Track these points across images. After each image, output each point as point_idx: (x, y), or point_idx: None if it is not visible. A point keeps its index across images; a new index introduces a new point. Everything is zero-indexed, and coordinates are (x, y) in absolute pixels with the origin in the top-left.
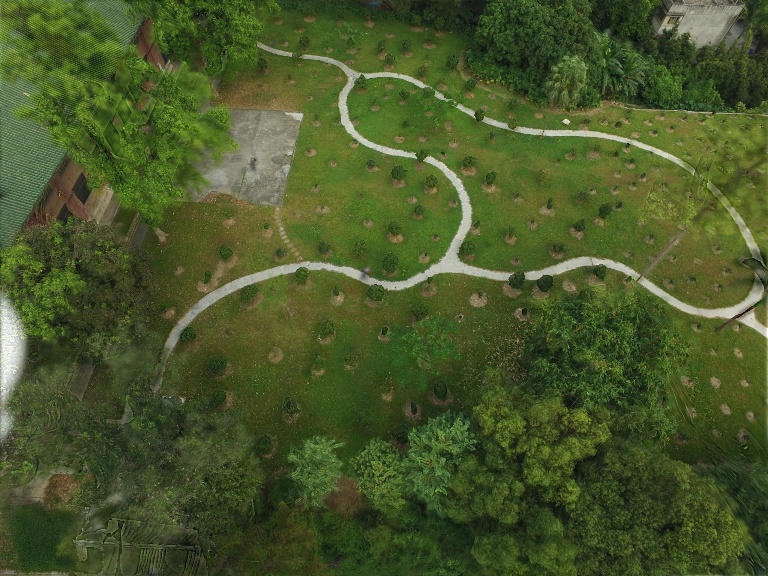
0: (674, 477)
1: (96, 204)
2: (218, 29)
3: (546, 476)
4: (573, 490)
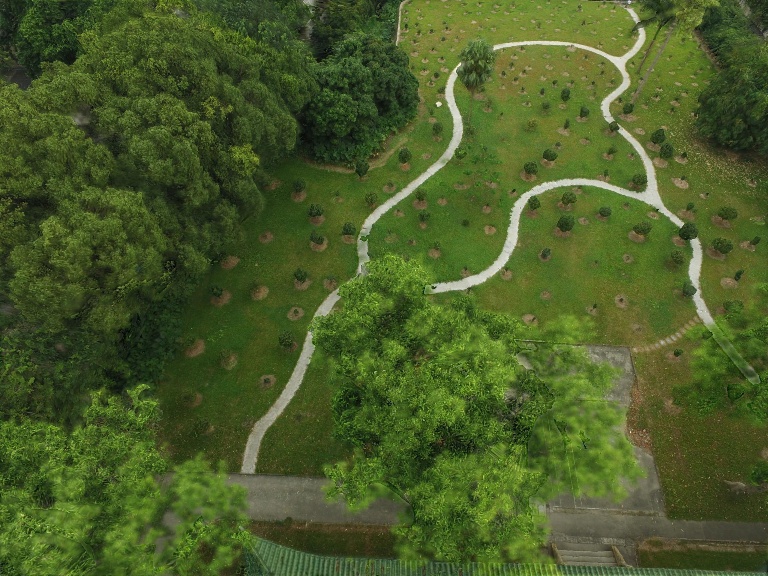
0: None
1: None
2: None
3: None
4: None
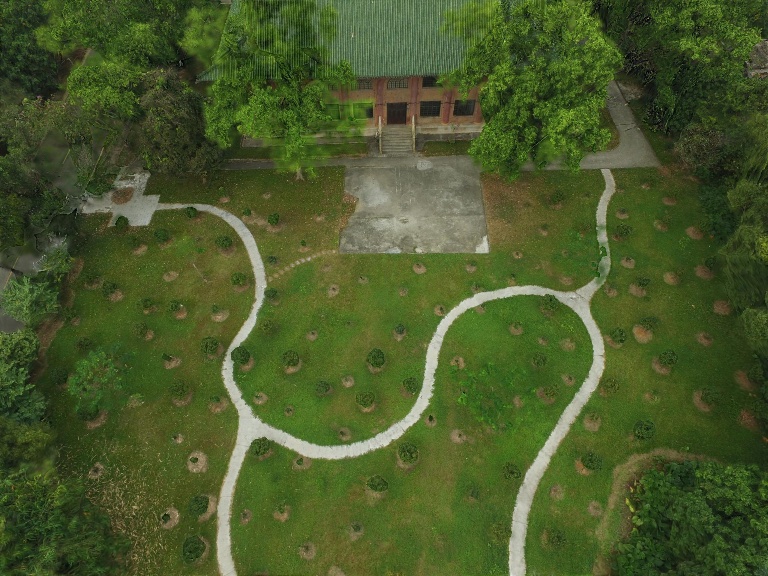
0: None
1: (332, 128)
2: None
3: None
4: None
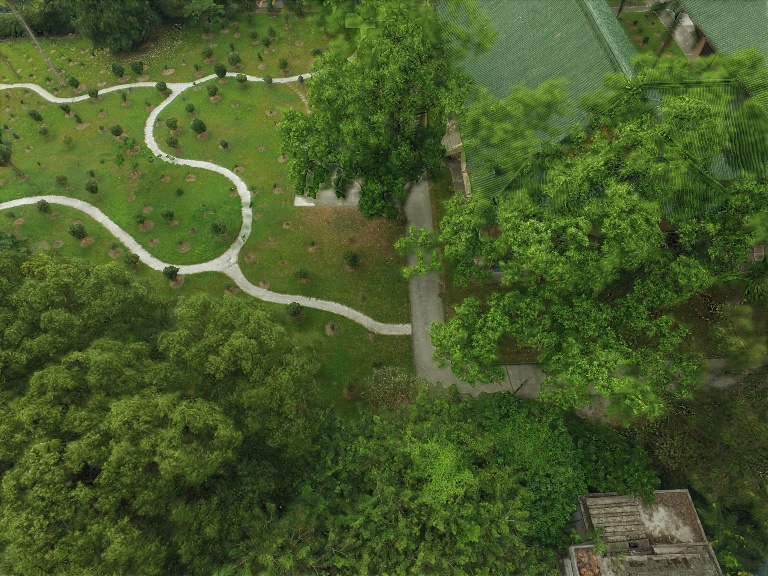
0: None
1: None
2: None
3: None
4: None
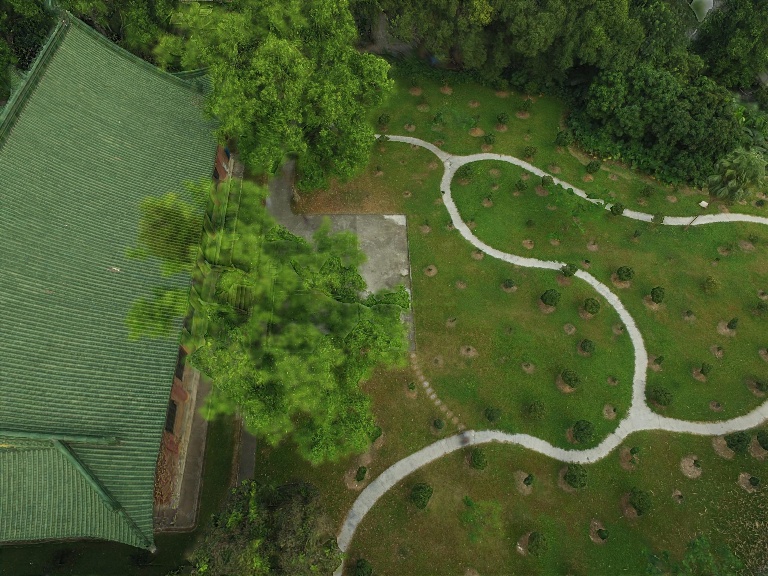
0: None
1: (191, 372)
2: (325, 141)
3: None
4: None
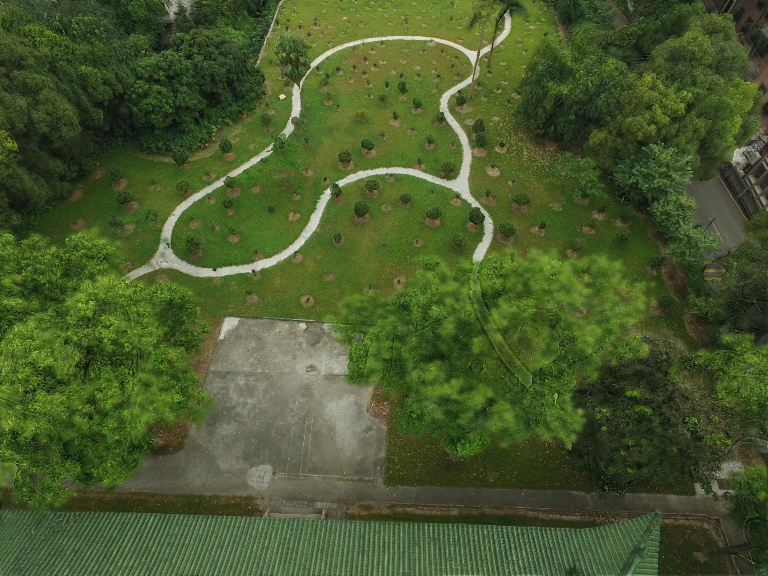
0: (671, 50)
1: None
2: None
3: (680, 104)
4: (686, 93)
